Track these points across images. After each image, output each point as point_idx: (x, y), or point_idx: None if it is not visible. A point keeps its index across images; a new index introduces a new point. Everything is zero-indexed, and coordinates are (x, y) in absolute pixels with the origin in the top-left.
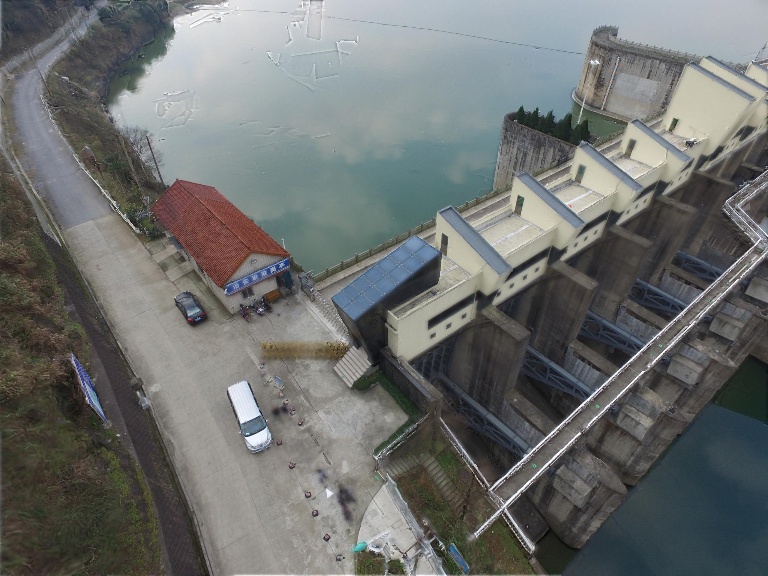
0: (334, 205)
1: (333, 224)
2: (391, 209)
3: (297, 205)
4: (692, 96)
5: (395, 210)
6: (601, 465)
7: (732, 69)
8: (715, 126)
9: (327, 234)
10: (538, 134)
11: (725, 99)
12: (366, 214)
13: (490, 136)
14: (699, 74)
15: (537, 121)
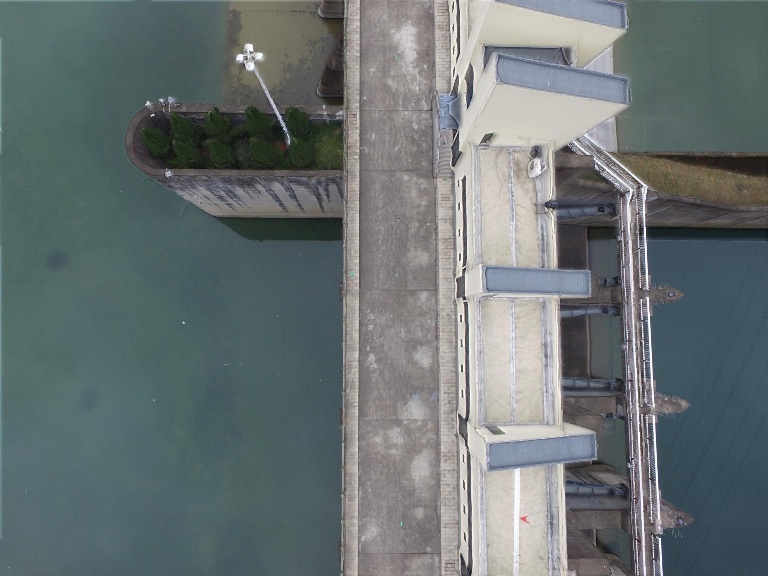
0: (46, 447)
1: (95, 484)
2: (128, 383)
3: (4, 505)
4: (517, 113)
5: (135, 380)
6: None
7: None
8: (564, 132)
9: (114, 510)
10: (233, 177)
11: (581, 109)
12: (110, 424)
13: (48, 38)
14: (527, 92)
15: (190, 125)
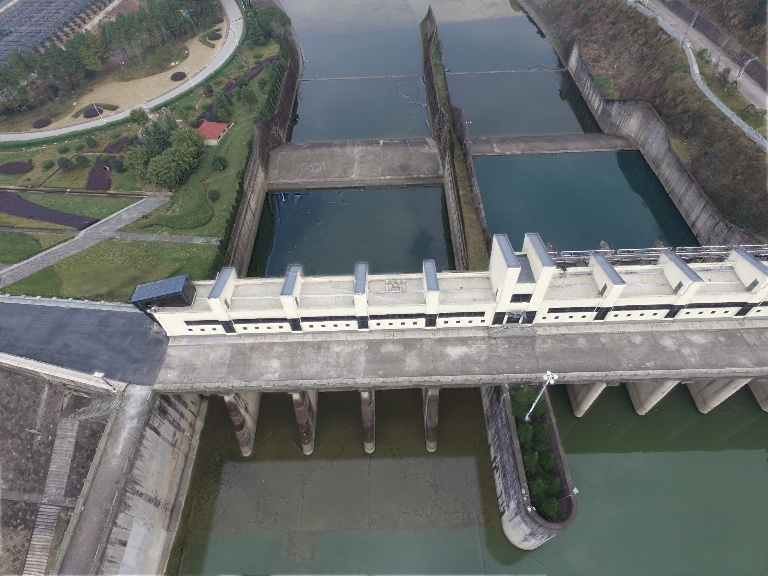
0: None
1: None
2: None
3: None
4: None
5: None
6: (715, 247)
7: (504, 254)
8: None
9: None
10: None
11: None
12: None
13: None
14: None
15: None
